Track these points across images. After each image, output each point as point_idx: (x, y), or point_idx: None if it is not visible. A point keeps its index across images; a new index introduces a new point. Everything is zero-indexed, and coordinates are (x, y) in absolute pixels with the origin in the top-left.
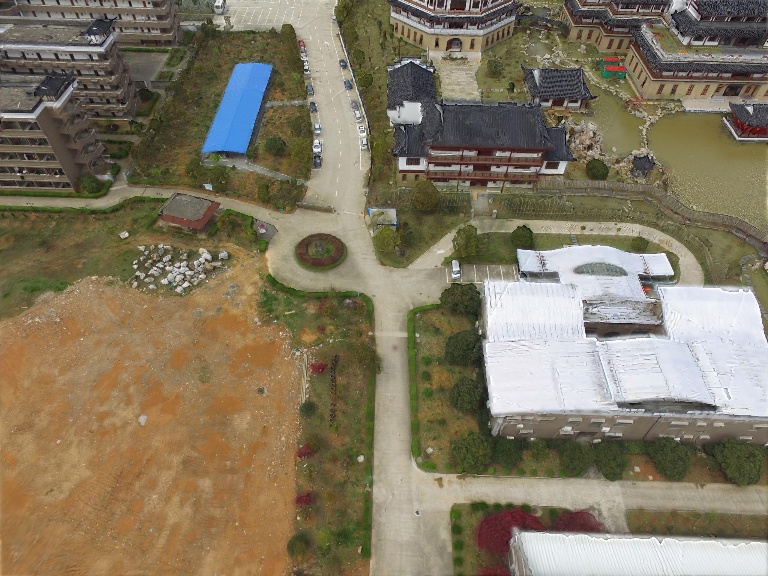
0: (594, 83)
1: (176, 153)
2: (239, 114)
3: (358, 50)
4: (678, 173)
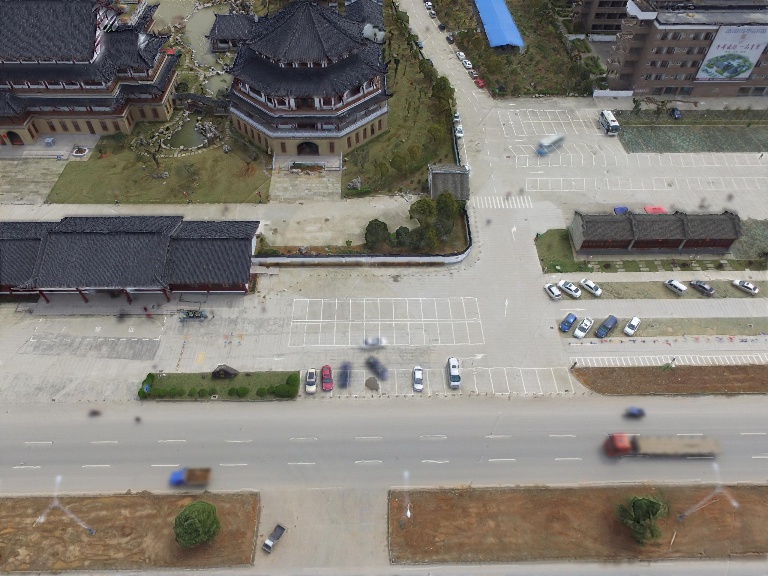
0: (193, 50)
1: (520, 2)
2: (491, 8)
3: (414, 35)
4: (186, 3)
